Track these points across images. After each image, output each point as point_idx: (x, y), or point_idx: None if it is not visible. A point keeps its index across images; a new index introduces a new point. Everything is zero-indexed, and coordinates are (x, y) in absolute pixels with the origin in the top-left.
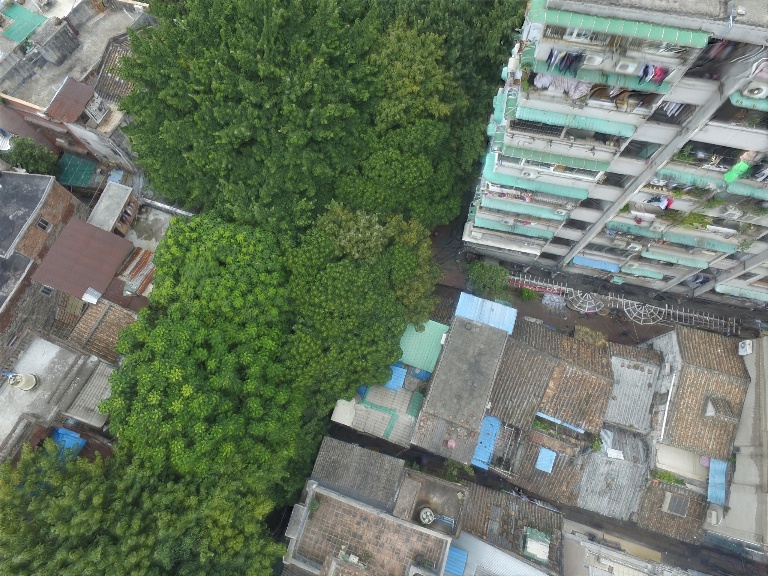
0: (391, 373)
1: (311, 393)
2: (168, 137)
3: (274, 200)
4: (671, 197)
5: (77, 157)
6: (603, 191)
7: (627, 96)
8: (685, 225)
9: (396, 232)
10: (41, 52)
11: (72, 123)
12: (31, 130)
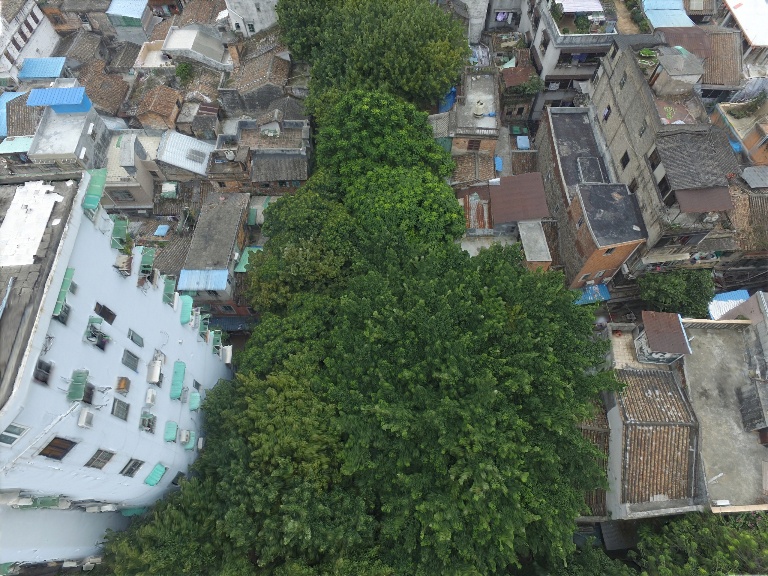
0: None
1: None
2: None
3: None
4: None
5: None
6: None
7: None
8: None
9: None
10: None
11: None
12: None
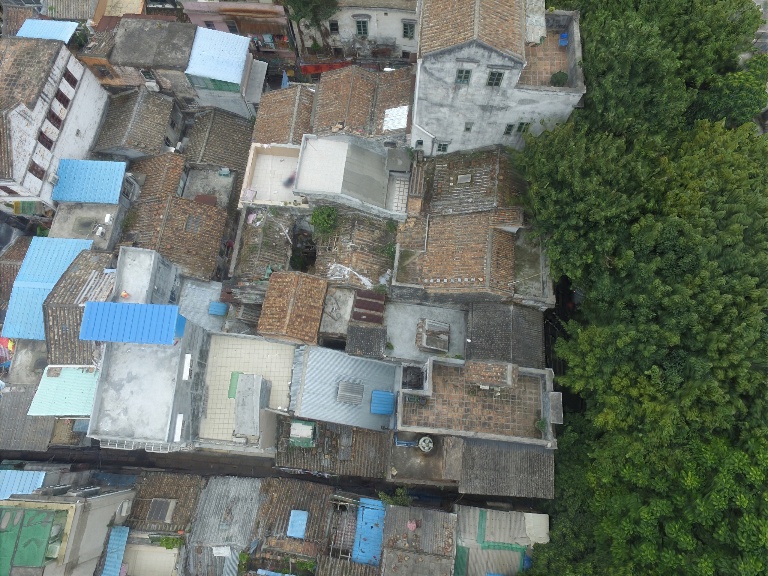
0: None
1: (590, 548)
2: None
3: None
4: None
5: None
6: None
7: None
8: None
9: None
10: None
11: None
12: None
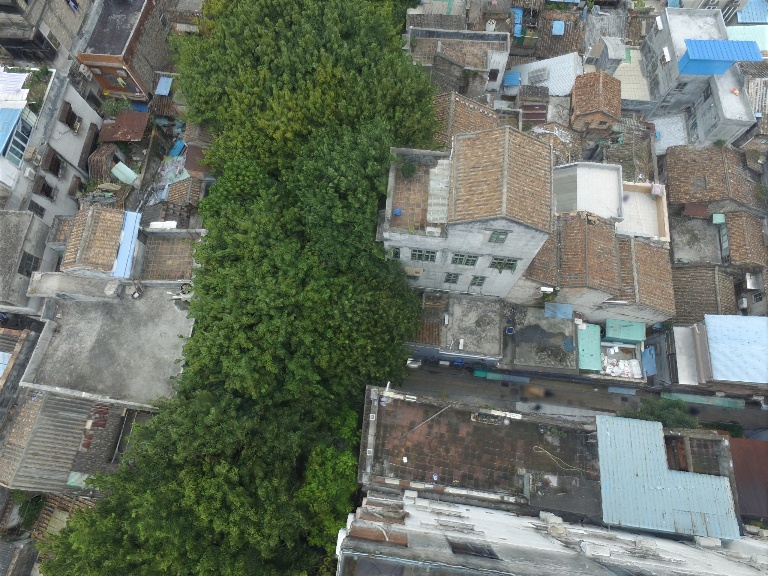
0: None
1: None
2: None
3: None
4: None
5: None
6: None
7: None
8: None
9: None
10: None
11: None
12: None
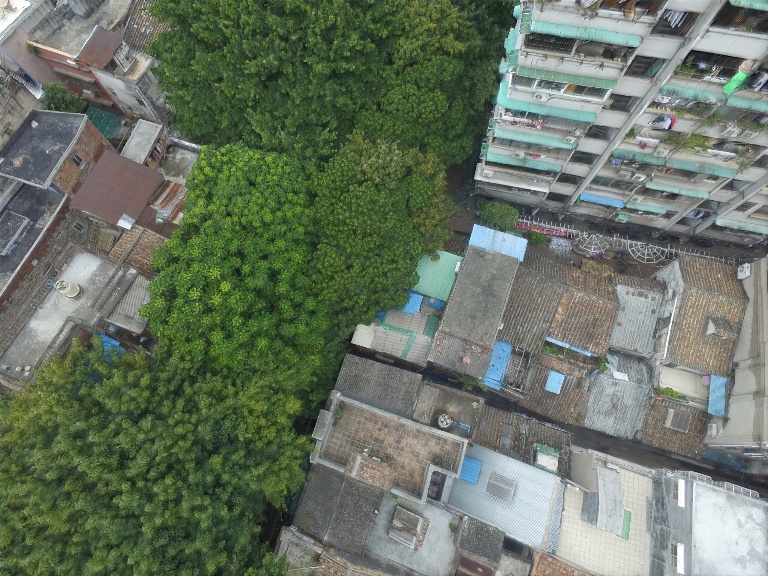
0: (408, 297)
1: (333, 314)
2: (200, 68)
3: (298, 131)
4: (674, 116)
5: (102, 110)
6: (610, 116)
7: (634, 4)
8: (687, 149)
9: (413, 163)
10: (70, 4)
11: (101, 71)
12: (59, 81)
